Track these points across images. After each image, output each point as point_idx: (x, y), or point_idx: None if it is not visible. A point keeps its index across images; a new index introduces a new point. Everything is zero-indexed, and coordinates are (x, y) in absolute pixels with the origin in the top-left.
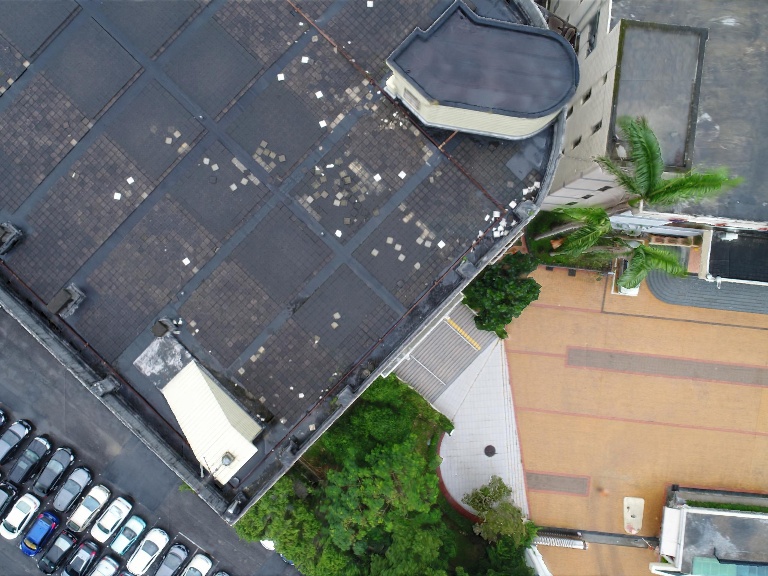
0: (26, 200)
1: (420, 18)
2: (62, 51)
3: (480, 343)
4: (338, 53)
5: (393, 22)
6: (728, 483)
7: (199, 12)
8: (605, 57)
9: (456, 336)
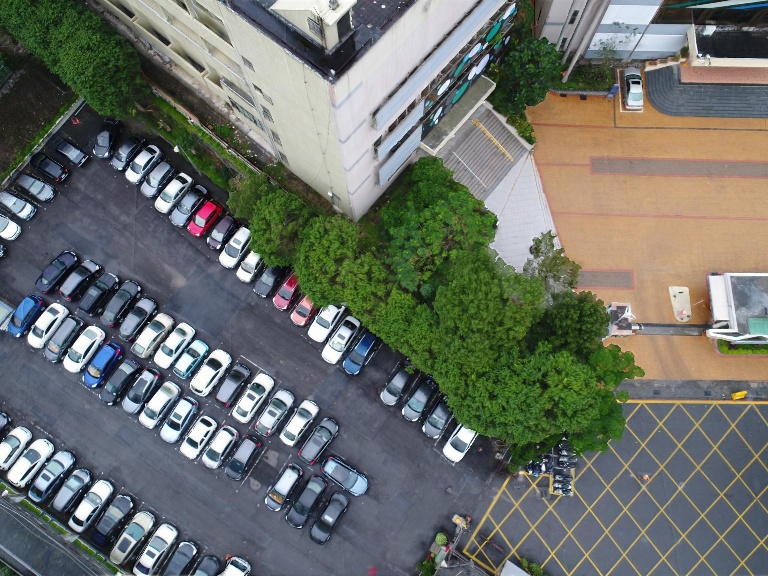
0: None
1: None
2: None
3: (512, 155)
4: None
5: None
6: (763, 268)
7: None
8: None
9: (491, 145)
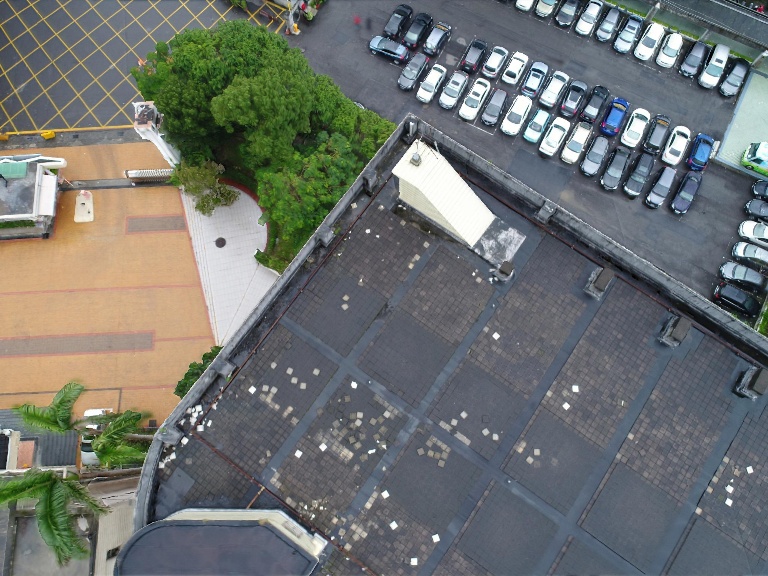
0: (663, 372)
1: None
2: (666, 531)
3: None
4: (381, 575)
5: None
6: None
7: None
8: None
9: None
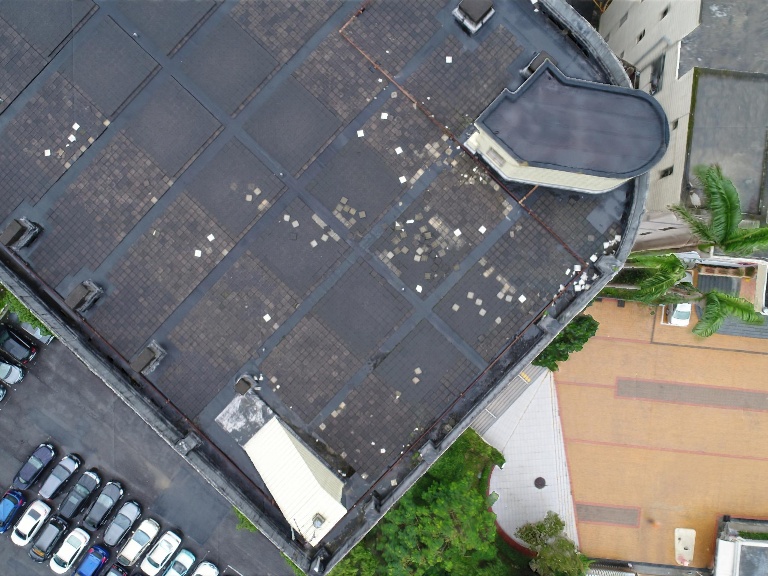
0: (107, 258)
1: (499, 73)
2: (142, 110)
3: (530, 375)
4: (417, 109)
5: (472, 77)
6: None
7: (278, 70)
8: (675, 103)
9: None
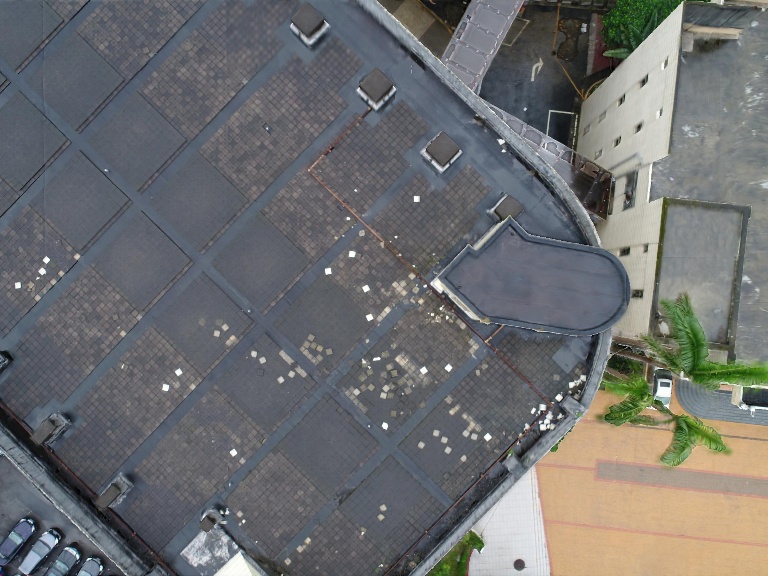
0: (75, 390)
1: (466, 213)
2: (112, 244)
3: None
4: (385, 247)
5: (439, 217)
6: None
7: (247, 207)
8: (645, 226)
9: None
